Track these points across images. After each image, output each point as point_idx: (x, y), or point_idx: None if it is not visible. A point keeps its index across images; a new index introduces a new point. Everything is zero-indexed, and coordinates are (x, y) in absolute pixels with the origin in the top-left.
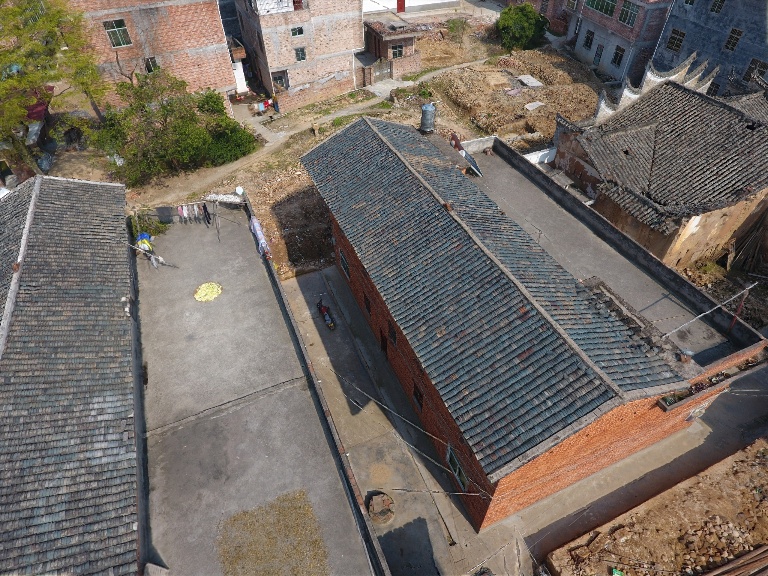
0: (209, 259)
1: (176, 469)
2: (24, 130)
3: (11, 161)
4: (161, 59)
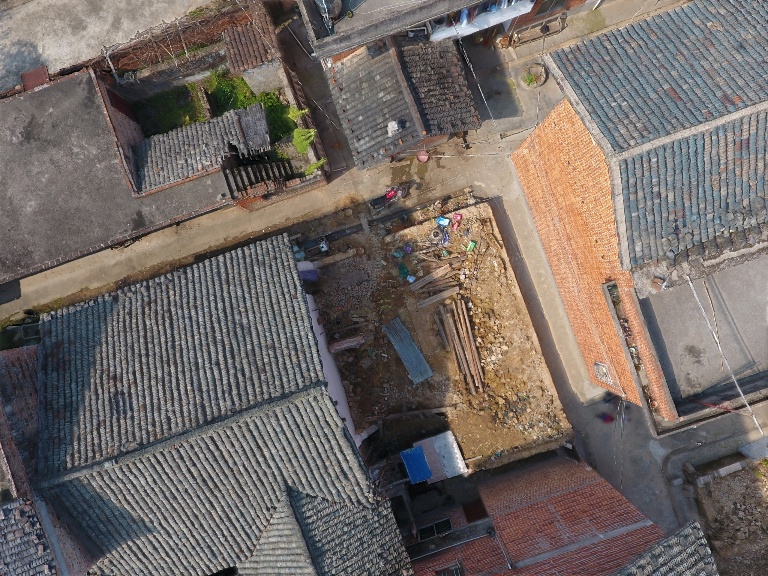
0: None
1: None
2: None
3: None
4: None
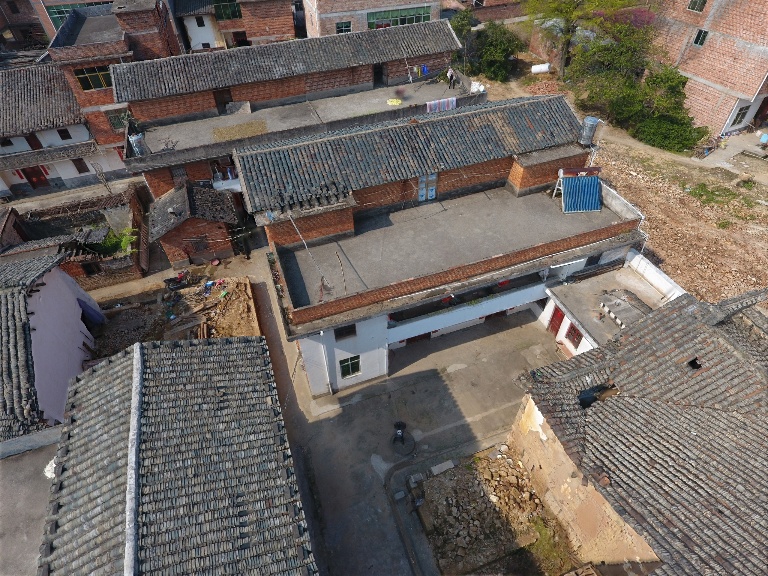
0: (423, 99)
1: (290, 109)
2: (571, 31)
3: (544, 43)
4: (711, 36)
